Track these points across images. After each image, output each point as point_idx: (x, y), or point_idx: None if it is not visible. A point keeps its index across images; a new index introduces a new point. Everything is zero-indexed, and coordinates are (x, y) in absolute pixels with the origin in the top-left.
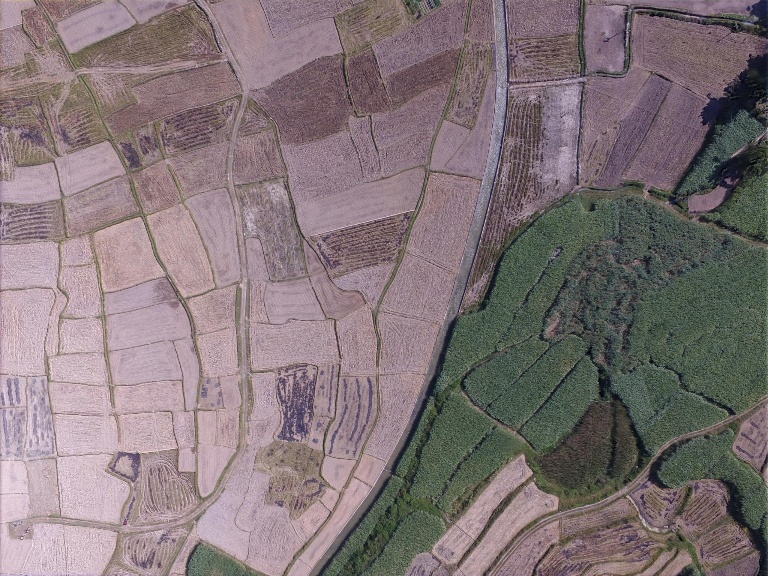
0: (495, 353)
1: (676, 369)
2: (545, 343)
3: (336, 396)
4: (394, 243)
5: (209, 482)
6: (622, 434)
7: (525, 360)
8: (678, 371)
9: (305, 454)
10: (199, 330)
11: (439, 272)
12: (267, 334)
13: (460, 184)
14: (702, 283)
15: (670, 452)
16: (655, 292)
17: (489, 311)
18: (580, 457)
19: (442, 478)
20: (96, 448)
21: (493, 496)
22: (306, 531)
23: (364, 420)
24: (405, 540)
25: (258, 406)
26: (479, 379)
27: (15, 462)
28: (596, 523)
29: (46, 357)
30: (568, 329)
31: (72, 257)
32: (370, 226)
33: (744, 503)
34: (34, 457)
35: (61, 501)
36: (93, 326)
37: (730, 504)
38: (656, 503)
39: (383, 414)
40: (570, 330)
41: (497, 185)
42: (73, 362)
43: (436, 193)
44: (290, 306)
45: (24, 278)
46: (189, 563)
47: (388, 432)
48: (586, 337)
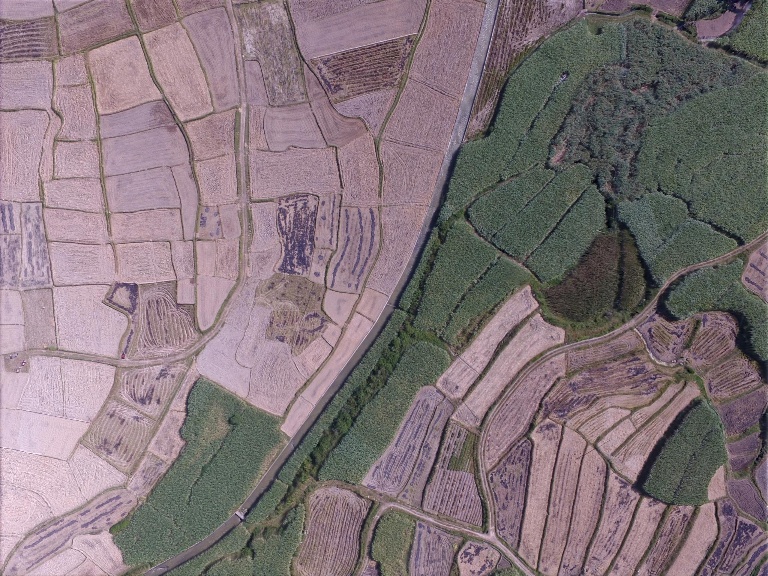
0: (500, 183)
1: (684, 197)
2: (551, 171)
3: (338, 227)
4: (396, 68)
5: (209, 315)
6: (629, 264)
7: (530, 188)
8: (686, 199)
9: (306, 288)
10: (197, 156)
11: (442, 99)
12: (267, 162)
13: (464, 7)
14: (711, 107)
15: (678, 282)
16: (663, 117)
17: (494, 137)
18: (587, 288)
19: (446, 310)
20: (93, 278)
21: (498, 328)
22: (308, 368)
23: (366, 253)
24: (409, 371)
25: (258, 237)
26: (484, 207)
27: (10, 292)
28: (603, 356)
29: (40, 182)
30: (574, 156)
31: (66, 76)
32: (372, 49)
33: (753, 333)
34: (29, 287)
35: (57, 333)
36: (88, 150)
37: (739, 337)
38: (664, 337)
39: (386, 247)
40: (576, 157)
41: (502, 8)
42: (68, 187)
43: (439, 16)
44: (290, 133)
45: (17, 98)
46: (189, 397)
47: (391, 265)
48: (593, 164)
